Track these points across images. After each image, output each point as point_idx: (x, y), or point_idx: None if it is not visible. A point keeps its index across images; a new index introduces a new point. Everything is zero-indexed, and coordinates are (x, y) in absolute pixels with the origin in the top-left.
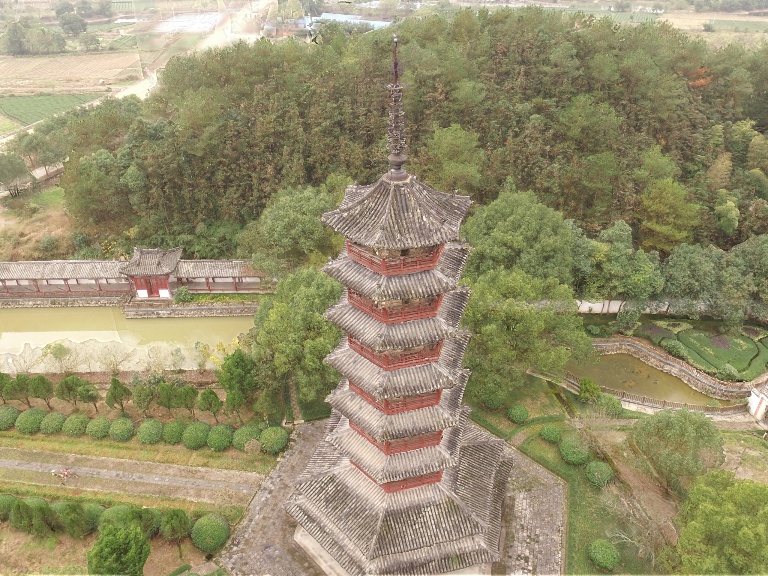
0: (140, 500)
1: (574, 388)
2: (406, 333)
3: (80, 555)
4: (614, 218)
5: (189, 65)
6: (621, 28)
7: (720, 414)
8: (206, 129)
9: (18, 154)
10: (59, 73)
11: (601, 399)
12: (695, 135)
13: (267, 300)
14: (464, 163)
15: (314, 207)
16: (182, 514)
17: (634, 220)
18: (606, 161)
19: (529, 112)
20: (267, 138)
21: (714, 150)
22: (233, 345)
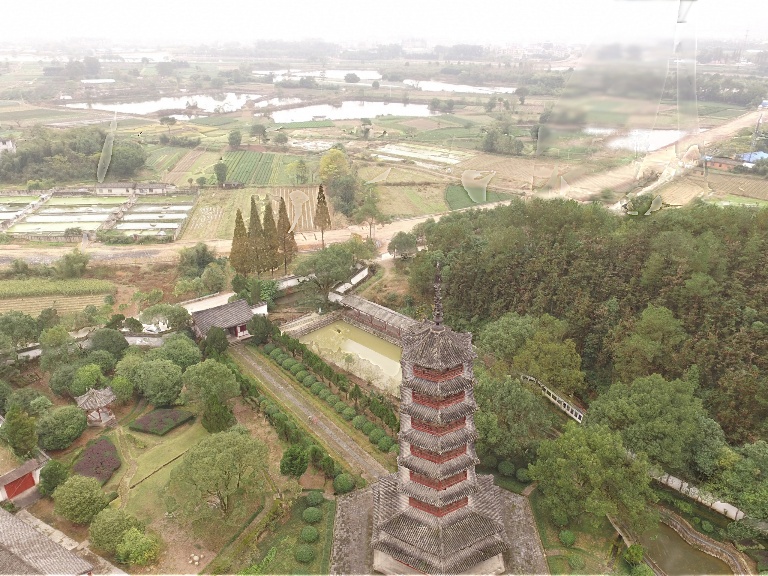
0: (331, 451)
1: None
2: (421, 410)
3: None
4: None
5: (517, 208)
6: None
7: None
8: (498, 255)
9: (423, 232)
10: (503, 172)
11: (638, 566)
12: None
13: None
14: (656, 340)
15: (516, 331)
16: (331, 462)
17: None
18: None
19: (756, 318)
20: (534, 273)
21: None
22: None
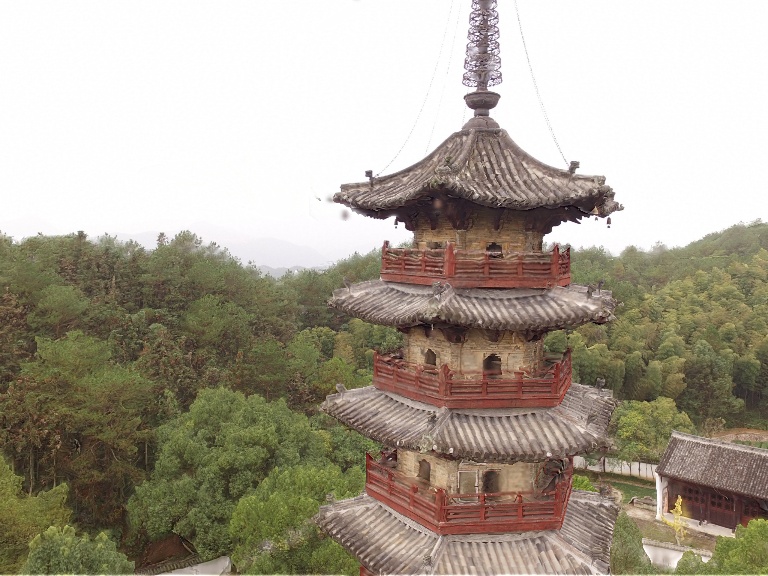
0: None
1: None
2: None
3: None
4: (298, 412)
5: None
6: None
7: None
8: None
9: None
10: None
11: None
12: None
13: None
14: None
15: None
16: None
17: None
18: (273, 350)
19: (145, 322)
20: None
21: None
22: None
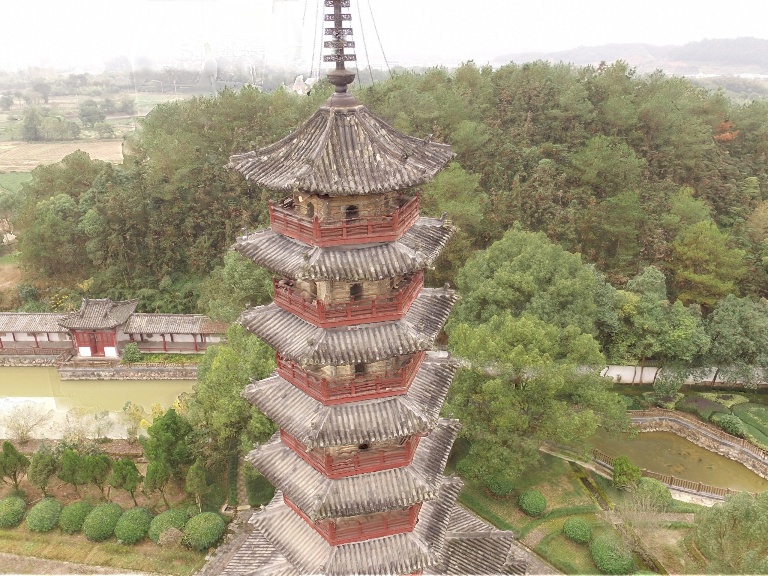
0: None
1: (605, 471)
2: (354, 343)
3: None
4: (642, 268)
5: (169, 112)
6: (636, 75)
7: None
8: (177, 171)
9: None
10: None
11: (642, 485)
12: (727, 185)
13: (215, 348)
14: None
15: None
16: None
17: (666, 271)
18: (629, 202)
19: (538, 157)
20: (244, 182)
21: (750, 203)
22: (174, 408)
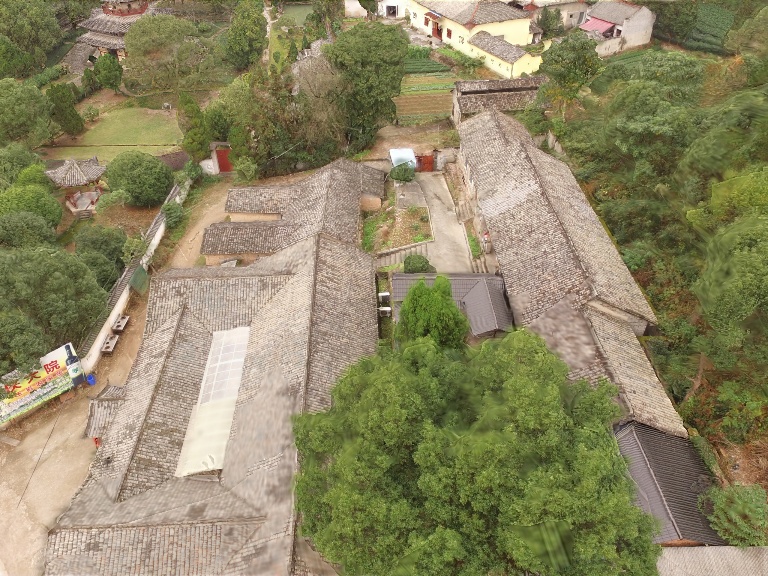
0: None
1: None
2: None
3: (84, 107)
4: None
5: None
6: None
7: (154, 3)
8: None
9: None
10: None
11: None
12: None
13: None
14: None
15: None
16: None
17: None
18: None
19: None
20: None
21: None
22: None
